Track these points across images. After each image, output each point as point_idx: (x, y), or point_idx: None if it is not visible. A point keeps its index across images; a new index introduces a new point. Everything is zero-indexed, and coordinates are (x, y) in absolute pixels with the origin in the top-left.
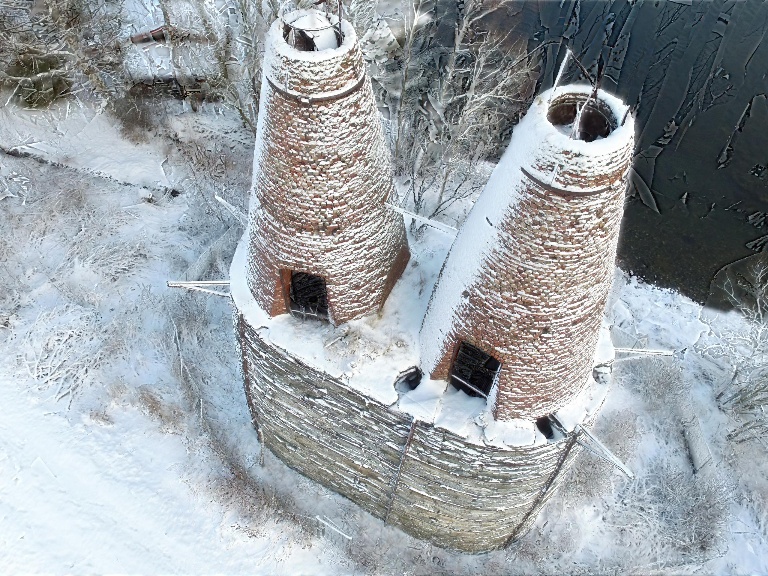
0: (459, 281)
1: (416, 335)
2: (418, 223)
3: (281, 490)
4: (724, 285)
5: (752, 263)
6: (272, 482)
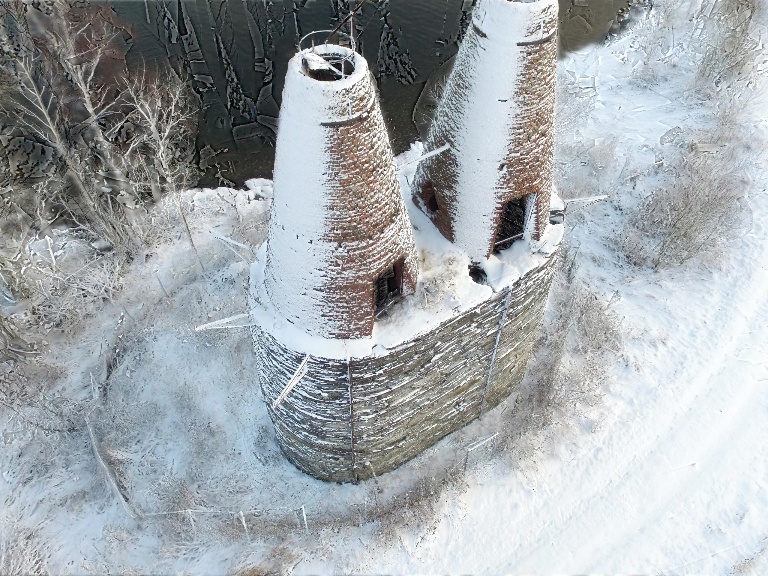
0: (491, 164)
1: (453, 247)
2: None
3: (413, 484)
4: (423, 120)
5: (427, 93)
6: (401, 490)
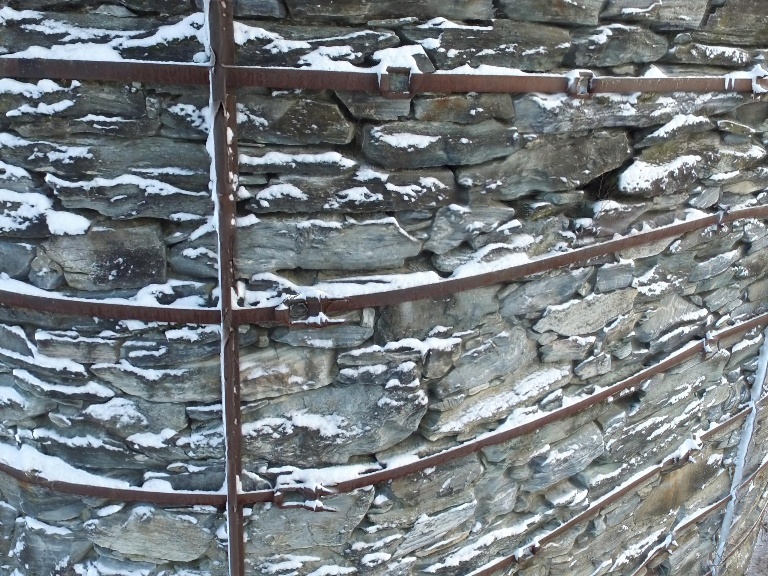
0: None
1: None
2: None
3: None
4: None
5: None
6: None
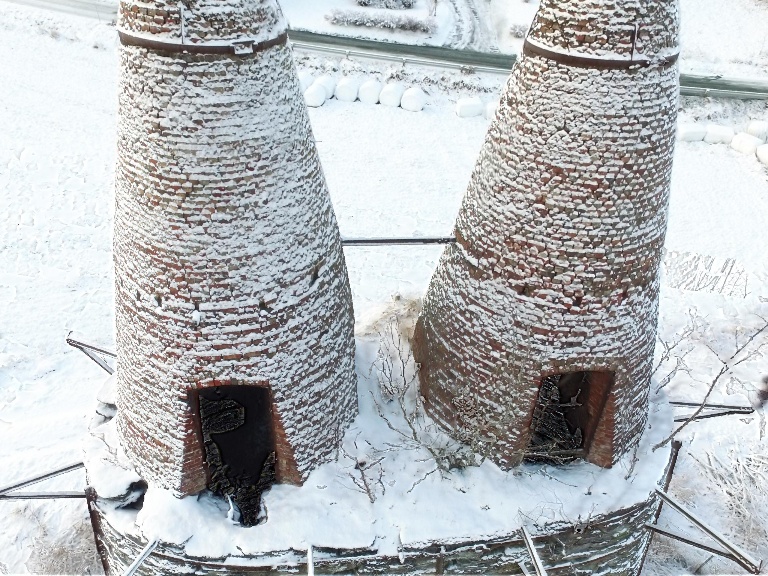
0: None
1: None
2: (469, 505)
3: None
4: None
5: None
6: None
